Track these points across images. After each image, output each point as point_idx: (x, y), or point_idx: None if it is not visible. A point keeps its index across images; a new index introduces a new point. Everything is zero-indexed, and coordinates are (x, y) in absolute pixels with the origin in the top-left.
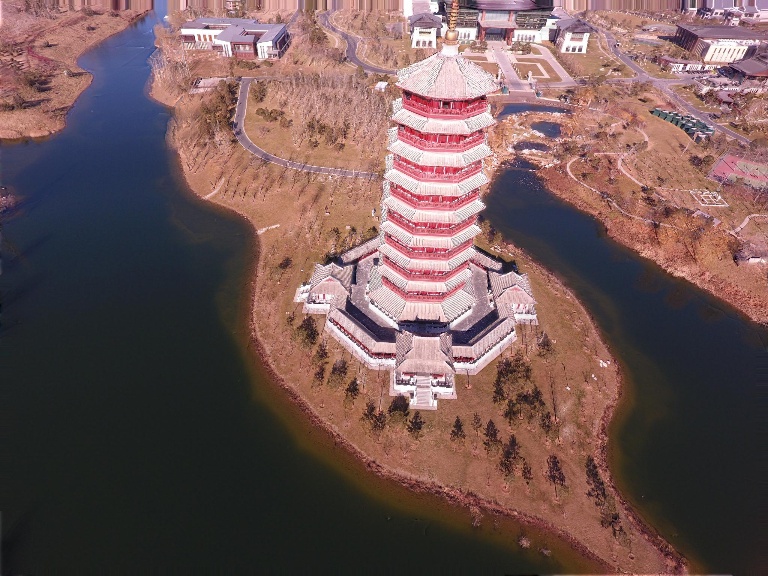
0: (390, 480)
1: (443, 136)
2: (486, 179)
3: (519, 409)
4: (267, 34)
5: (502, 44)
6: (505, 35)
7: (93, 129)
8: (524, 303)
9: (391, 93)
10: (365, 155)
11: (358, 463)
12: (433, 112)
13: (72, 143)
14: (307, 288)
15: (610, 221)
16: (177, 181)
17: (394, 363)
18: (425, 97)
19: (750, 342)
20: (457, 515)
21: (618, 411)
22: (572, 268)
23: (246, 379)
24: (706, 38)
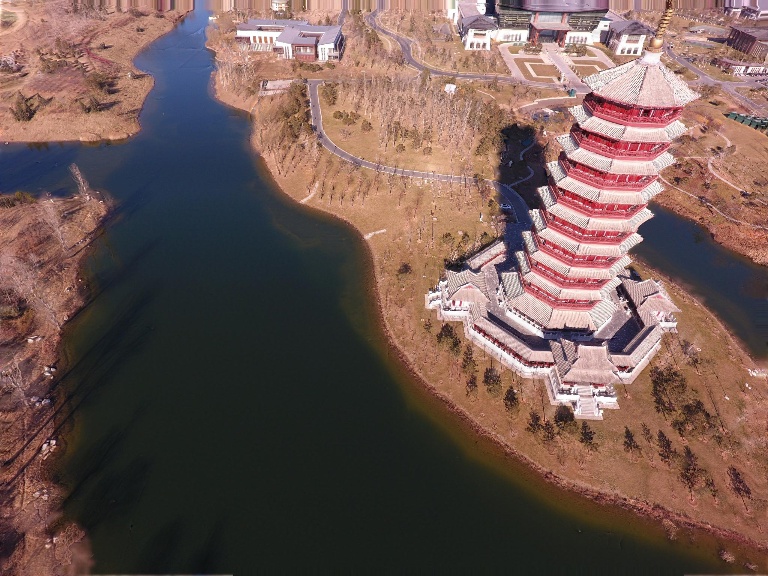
0: (572, 492)
1: (635, 144)
2: (661, 187)
3: (685, 419)
4: (325, 36)
5: (554, 46)
6: (557, 37)
7: (168, 132)
8: (667, 311)
9: (461, 96)
10: (455, 159)
11: (534, 474)
12: (633, 120)
13: None
14: (437, 295)
15: (714, 226)
16: (268, 185)
17: (549, 372)
18: (633, 105)
19: None
20: (649, 528)
21: None
22: (688, 274)
23: (395, 387)
24: (764, 40)
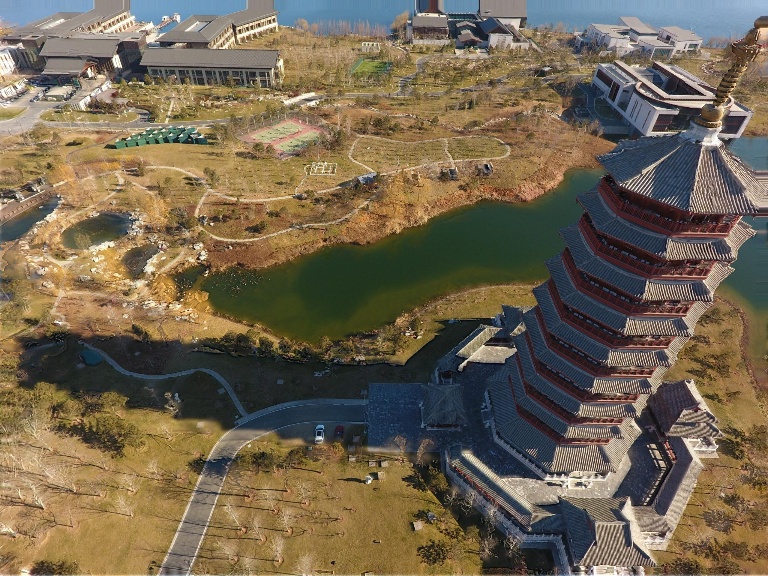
0: None
1: None
2: None
3: None
4: None
5: None
6: None
7: None
8: None
9: None
10: None
11: None
12: None
13: None
14: None
15: (343, 236)
16: None
17: None
18: None
19: (453, 220)
20: None
21: None
22: (424, 282)
23: None
24: None
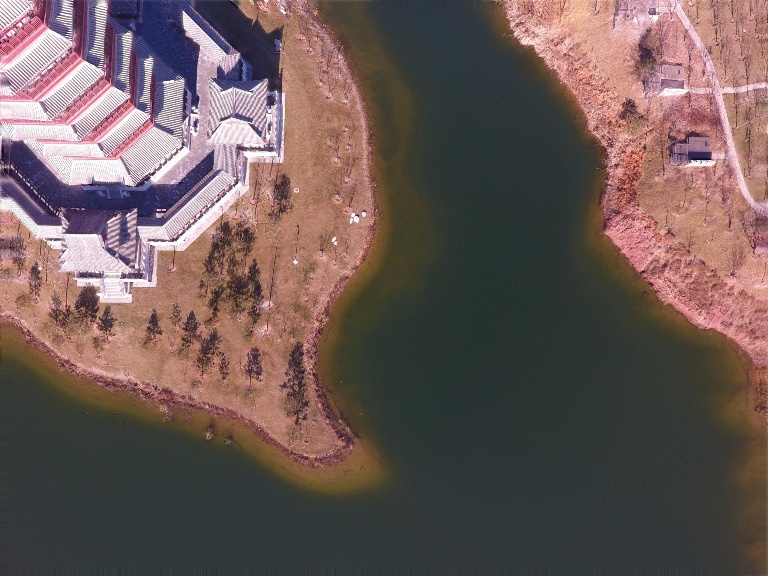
0: (85, 379)
1: None
2: (22, 2)
3: (228, 295)
4: None
5: None
6: None
7: None
8: None
9: None
10: None
11: (52, 362)
12: None
13: None
14: None
15: None
16: None
17: None
18: None
19: None
20: (151, 410)
21: (353, 282)
22: (376, 31)
23: None
24: None
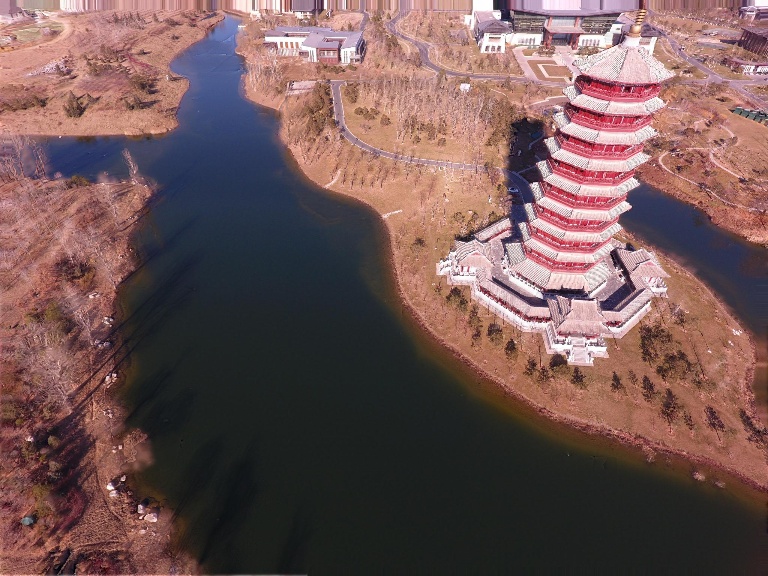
0: (563, 423)
1: (618, 118)
2: None
3: (669, 367)
4: (348, 41)
5: (567, 49)
6: (570, 40)
7: (203, 127)
8: (658, 276)
9: (475, 94)
10: (467, 149)
11: (530, 409)
12: (616, 96)
13: (187, 139)
14: (447, 263)
15: (712, 209)
16: (295, 172)
17: (546, 326)
18: (614, 82)
19: None
20: (630, 453)
21: (758, 373)
22: (684, 251)
23: (408, 339)
24: None
